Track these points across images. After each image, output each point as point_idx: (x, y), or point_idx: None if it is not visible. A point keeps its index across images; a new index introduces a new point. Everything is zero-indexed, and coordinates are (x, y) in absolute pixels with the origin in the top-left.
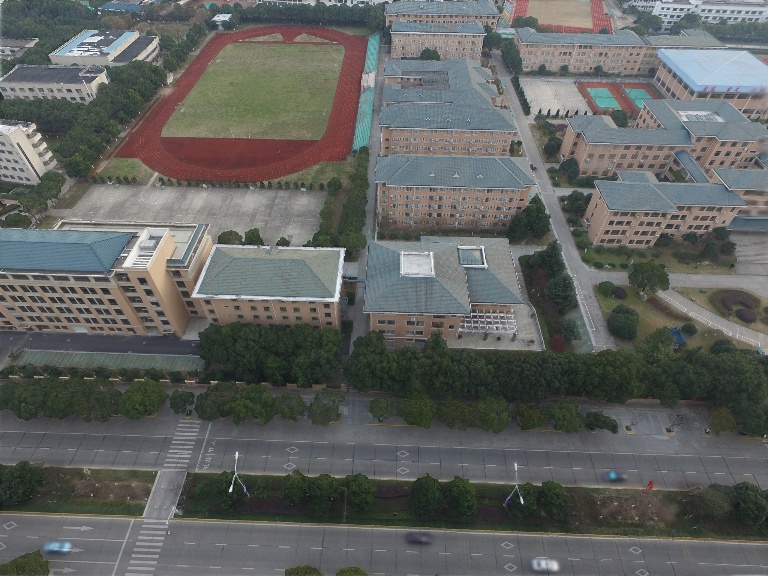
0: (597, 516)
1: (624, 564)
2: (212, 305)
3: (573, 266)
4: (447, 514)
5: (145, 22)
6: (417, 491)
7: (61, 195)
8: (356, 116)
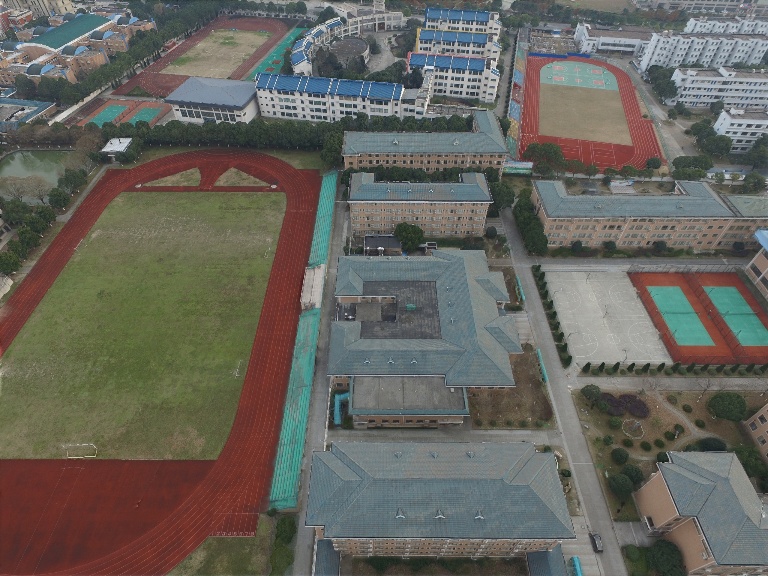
0: None
1: None
2: None
3: None
4: None
5: (12, 149)
6: None
7: None
8: (287, 380)
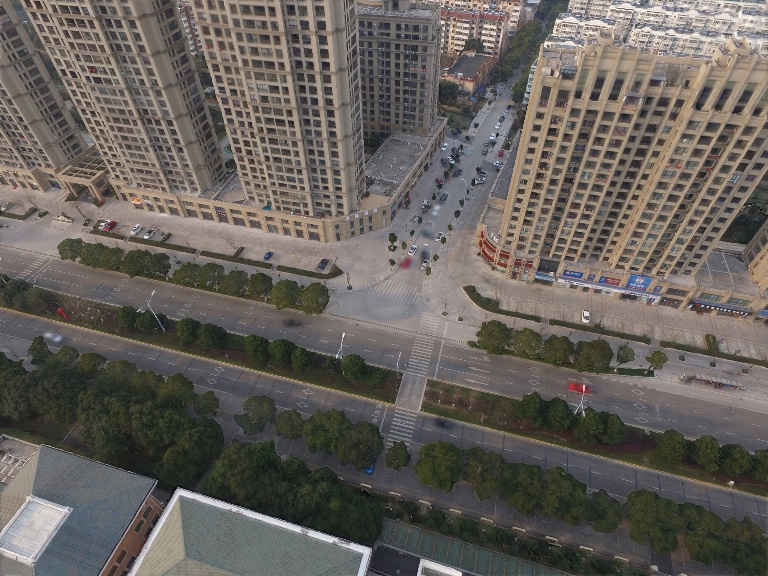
0: (112, 314)
1: (123, 294)
2: None
3: None
4: None
5: None
6: (217, 334)
7: None
8: None
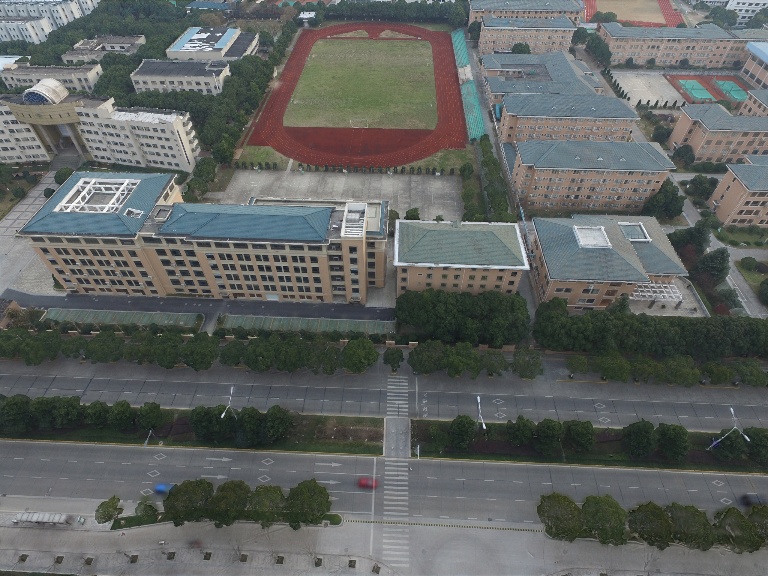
0: None
1: None
2: (407, 273)
3: (710, 244)
4: (659, 456)
5: (232, 20)
6: (635, 434)
7: None
8: (462, 107)
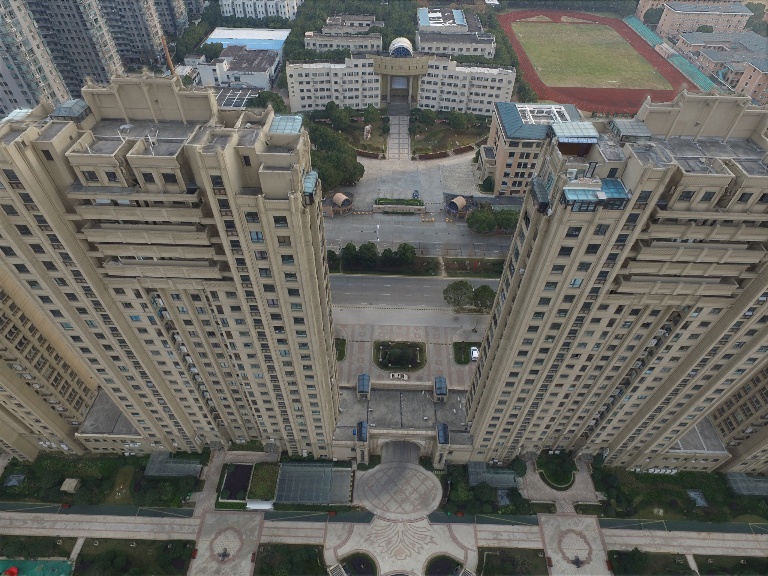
0: None
1: None
2: None
3: None
4: None
5: None
6: None
7: None
8: (682, 74)
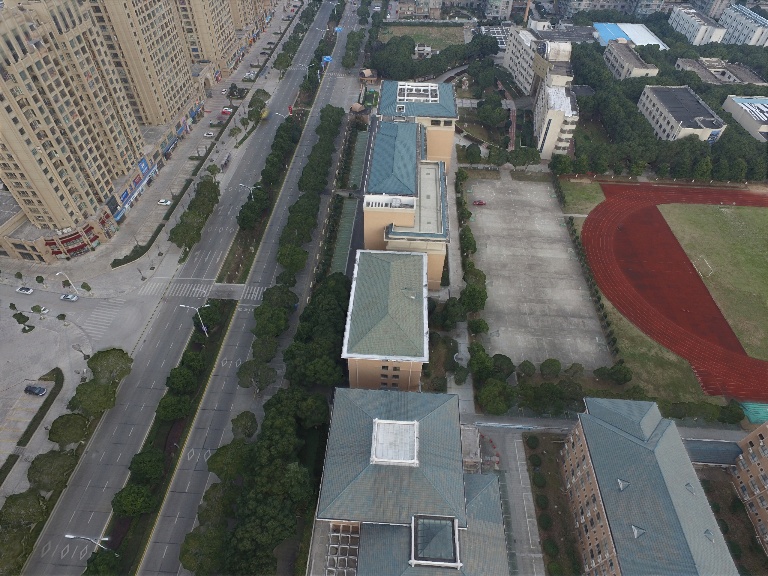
0: None
1: None
2: None
3: None
4: None
5: None
6: None
7: (529, 170)
8: None
